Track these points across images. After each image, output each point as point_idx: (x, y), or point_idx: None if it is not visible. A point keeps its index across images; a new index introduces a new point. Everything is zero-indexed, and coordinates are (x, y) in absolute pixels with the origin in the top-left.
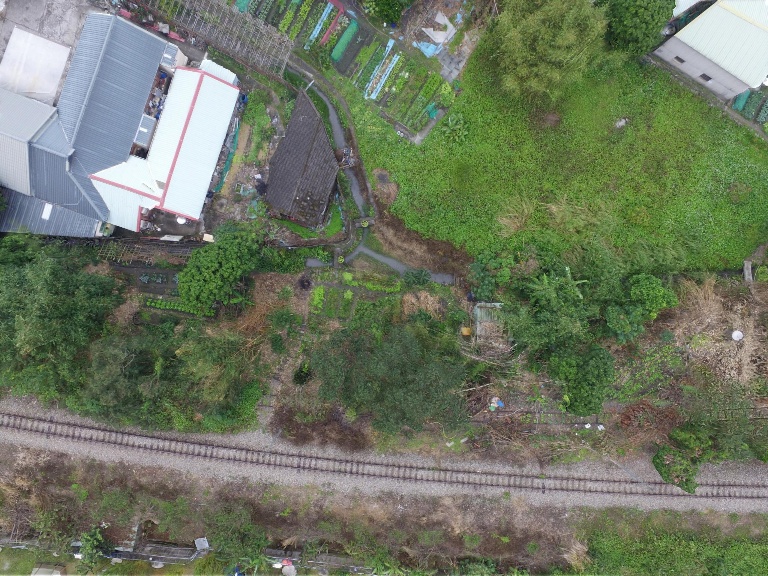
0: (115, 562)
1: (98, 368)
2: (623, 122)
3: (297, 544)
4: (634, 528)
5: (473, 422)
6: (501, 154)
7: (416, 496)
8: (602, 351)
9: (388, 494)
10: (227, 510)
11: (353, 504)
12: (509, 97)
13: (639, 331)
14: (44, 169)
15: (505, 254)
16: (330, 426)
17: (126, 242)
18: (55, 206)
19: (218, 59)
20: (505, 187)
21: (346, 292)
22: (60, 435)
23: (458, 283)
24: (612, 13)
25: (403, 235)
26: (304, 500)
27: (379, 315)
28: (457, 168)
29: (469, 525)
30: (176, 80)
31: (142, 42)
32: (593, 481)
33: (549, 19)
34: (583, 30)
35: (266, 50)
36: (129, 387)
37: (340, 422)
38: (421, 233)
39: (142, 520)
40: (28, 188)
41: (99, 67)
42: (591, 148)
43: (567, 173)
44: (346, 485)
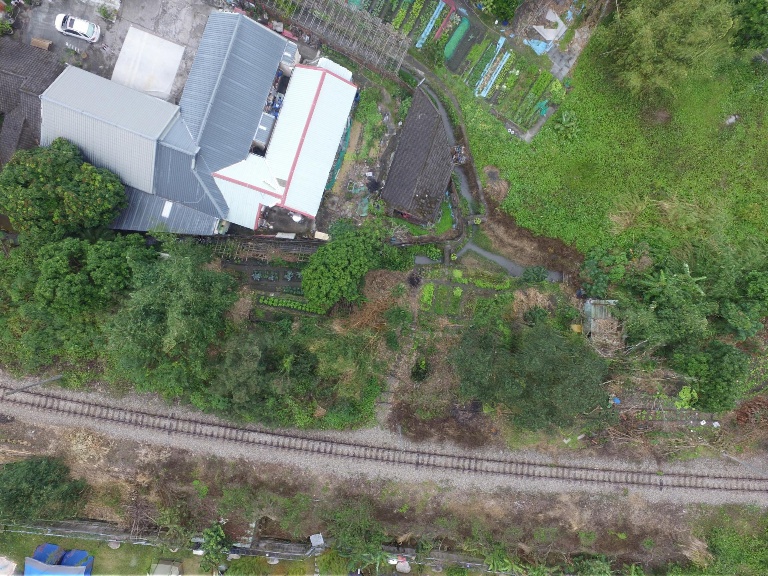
0: (231, 558)
1: (231, 365)
2: (733, 119)
3: (410, 540)
4: (752, 525)
5: (589, 419)
6: (612, 151)
7: (534, 493)
8: (734, 347)
9: (506, 491)
10: (345, 506)
11: (470, 500)
12: (620, 94)
13: (758, 328)
14: (169, 167)
15: (617, 251)
16: (449, 423)
17: (239, 240)
18: (175, 204)
19: (331, 57)
20: (615, 184)
21: (455, 289)
22: (182, 432)
23: (567, 280)
24: (737, 10)
25: (514, 232)
26: (422, 496)
27: (501, 312)
28: (568, 165)
29: (586, 522)
30: (295, 78)
31: (265, 40)
32: (711, 478)
33: (680, 16)
34: (714, 27)
35: (383, 48)
36: (258, 384)
37: (457, 419)
38: (532, 230)
39: (259, 516)
40: (151, 186)
41: (225, 65)
42: (701, 145)
43: (678, 170)
44: (464, 482)
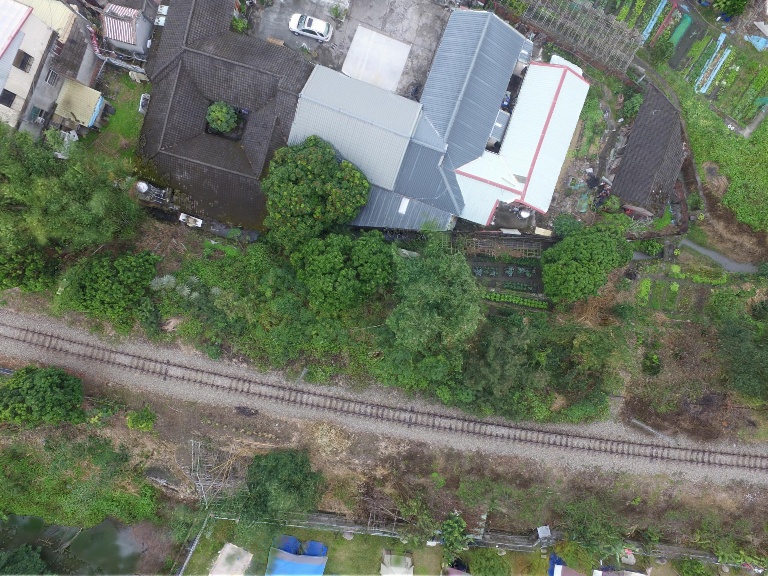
0: None
1: (494, 358)
2: None
3: (633, 533)
4: None
5: None
6: None
7: (766, 485)
8: None
9: (738, 483)
10: (579, 499)
11: (702, 493)
12: None
13: None
14: (414, 164)
15: None
16: (683, 416)
17: None
18: (412, 200)
19: None
20: None
21: (672, 284)
22: (422, 425)
23: None
24: None
25: (734, 228)
26: (654, 489)
27: None
28: None
29: None
30: (530, 76)
31: (507, 38)
32: None
33: None
34: None
35: (614, 45)
36: None
37: (688, 412)
38: (752, 225)
39: (491, 508)
40: (392, 183)
41: (474, 63)
42: None
43: None
44: (697, 474)
